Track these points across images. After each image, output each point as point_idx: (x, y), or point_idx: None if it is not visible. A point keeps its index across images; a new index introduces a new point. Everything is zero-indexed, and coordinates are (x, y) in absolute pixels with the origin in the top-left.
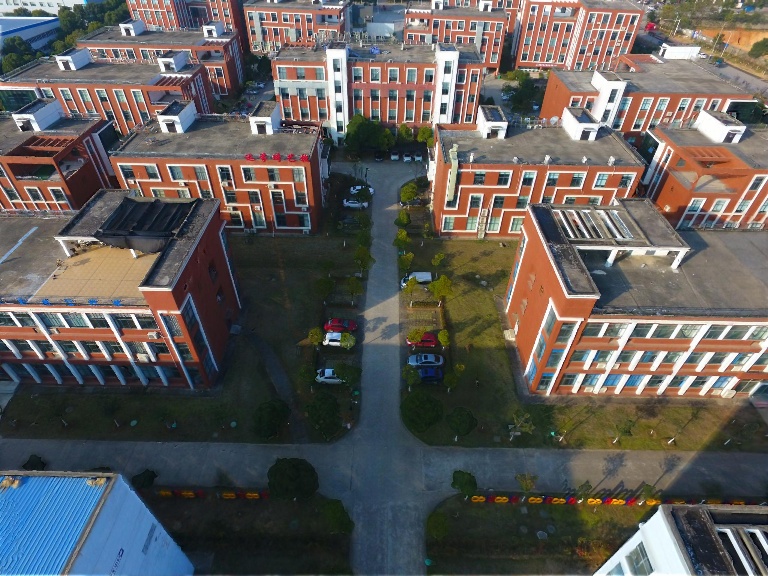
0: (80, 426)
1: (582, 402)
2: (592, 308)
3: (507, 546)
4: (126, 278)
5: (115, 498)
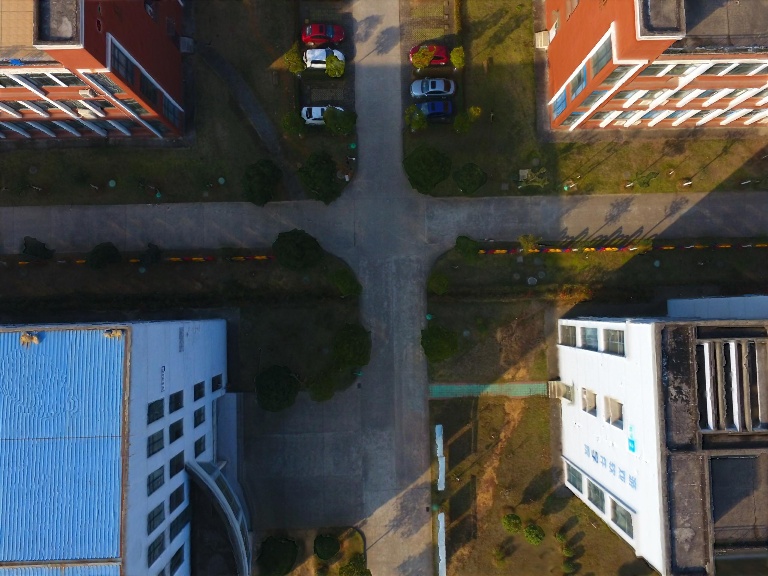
0: (56, 190)
1: (607, 138)
2: (665, 49)
3: (499, 293)
4: (5, 7)
5: (138, 344)
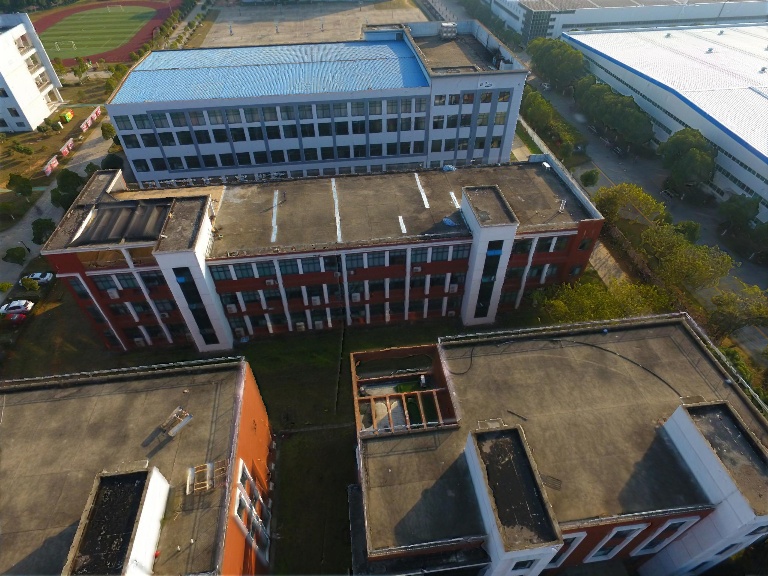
0: None
1: None
2: None
3: None
4: None
5: None
